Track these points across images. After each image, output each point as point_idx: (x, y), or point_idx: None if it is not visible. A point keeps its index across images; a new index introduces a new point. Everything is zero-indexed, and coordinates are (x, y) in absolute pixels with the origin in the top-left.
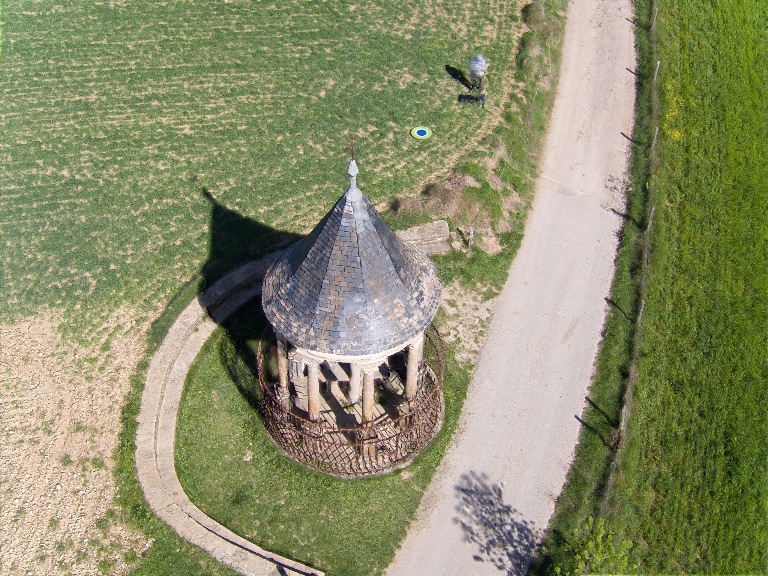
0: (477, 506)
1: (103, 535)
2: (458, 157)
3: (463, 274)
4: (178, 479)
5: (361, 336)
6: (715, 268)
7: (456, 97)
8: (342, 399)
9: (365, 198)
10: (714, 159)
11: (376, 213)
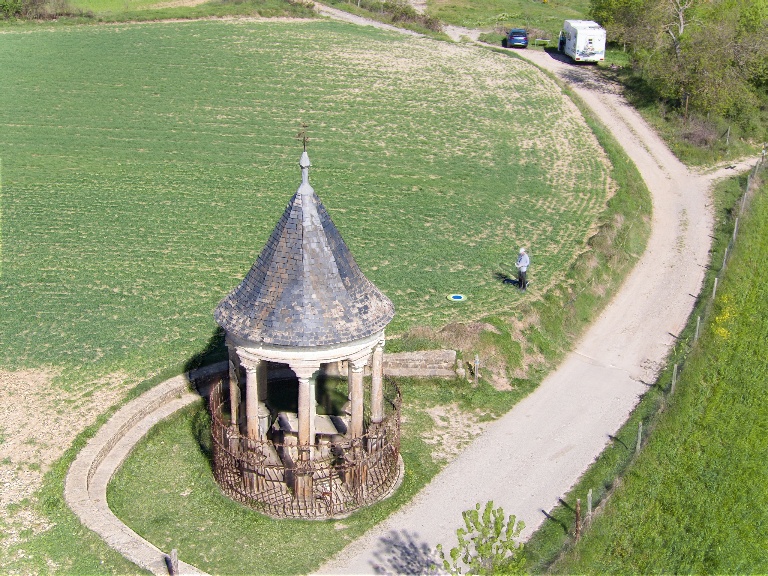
0: (405, 559)
1: (10, 514)
2: (486, 315)
3: (464, 399)
4: (106, 492)
5: (293, 327)
6: (739, 428)
7: (501, 281)
8: (297, 459)
9: (316, 197)
10: (763, 359)
11: (327, 216)
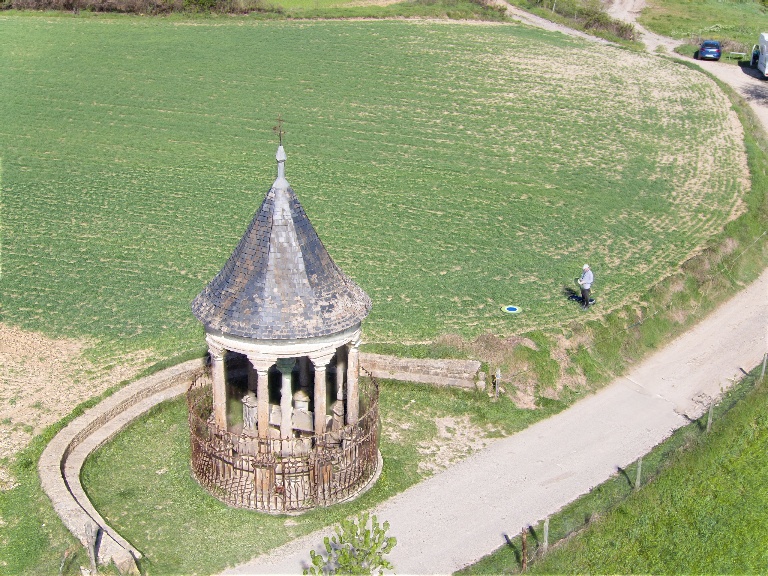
0: None
1: None
2: (533, 330)
3: (478, 412)
4: (84, 460)
5: (251, 319)
6: (767, 477)
7: (567, 296)
8: (276, 452)
9: (292, 192)
10: None
11: (302, 212)
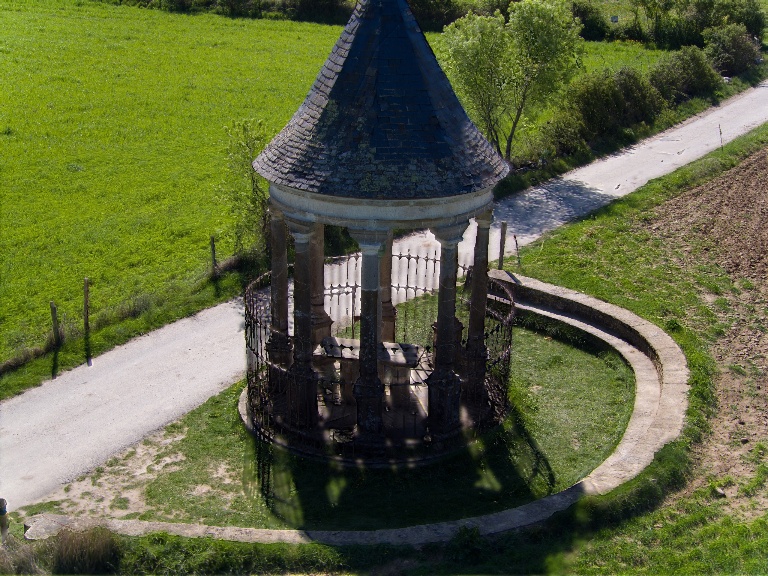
0: None
1: None
2: None
3: None
4: None
5: None
6: None
7: None
8: None
9: None
10: None
11: None
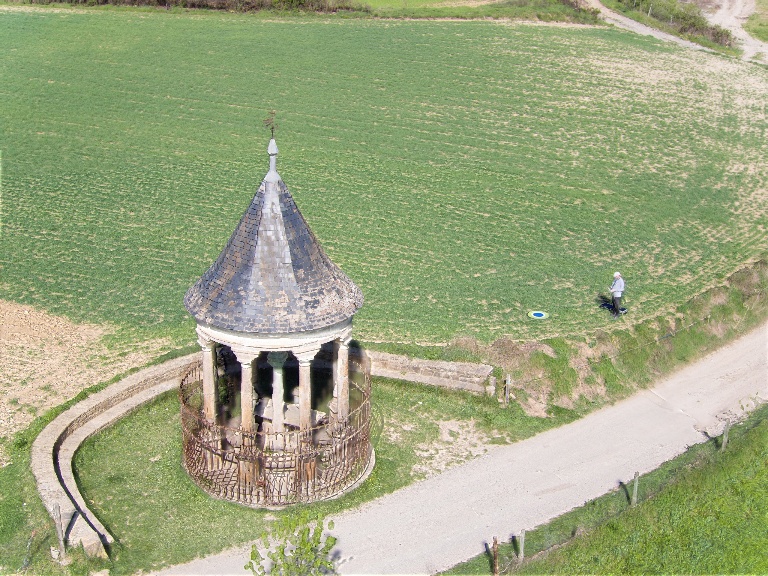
0: None
1: None
2: (556, 336)
3: (485, 418)
4: (80, 444)
5: (234, 311)
6: None
7: (600, 304)
8: None
9: (283, 185)
10: None
11: (292, 206)
